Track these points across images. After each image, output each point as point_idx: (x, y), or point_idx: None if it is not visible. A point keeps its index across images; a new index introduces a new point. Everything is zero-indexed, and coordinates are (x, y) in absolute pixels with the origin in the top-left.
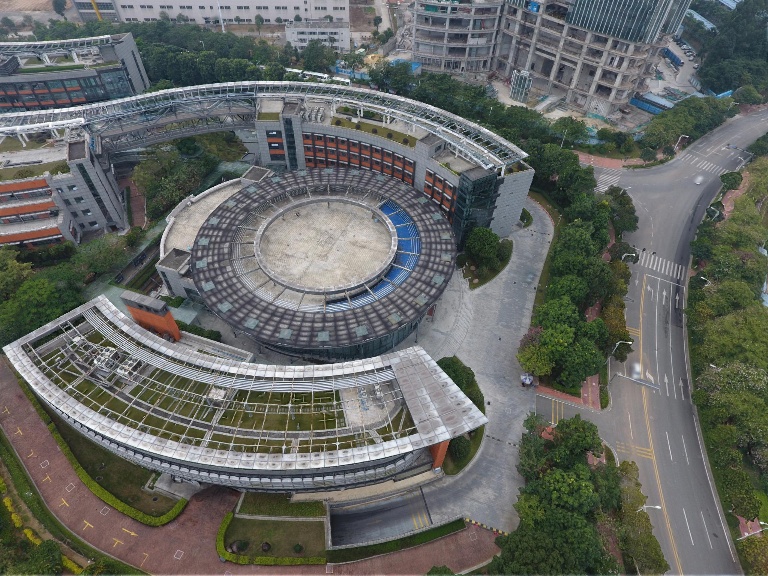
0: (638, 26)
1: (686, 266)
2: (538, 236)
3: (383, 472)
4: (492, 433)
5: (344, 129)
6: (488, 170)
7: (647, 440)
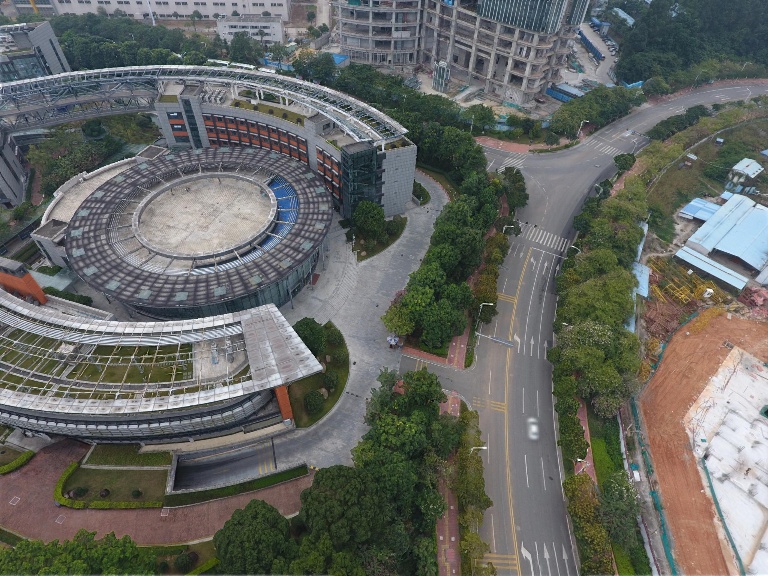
0: (539, 17)
1: (571, 240)
2: (433, 213)
3: (220, 419)
4: (352, 390)
5: (241, 110)
6: (367, 145)
7: (503, 395)
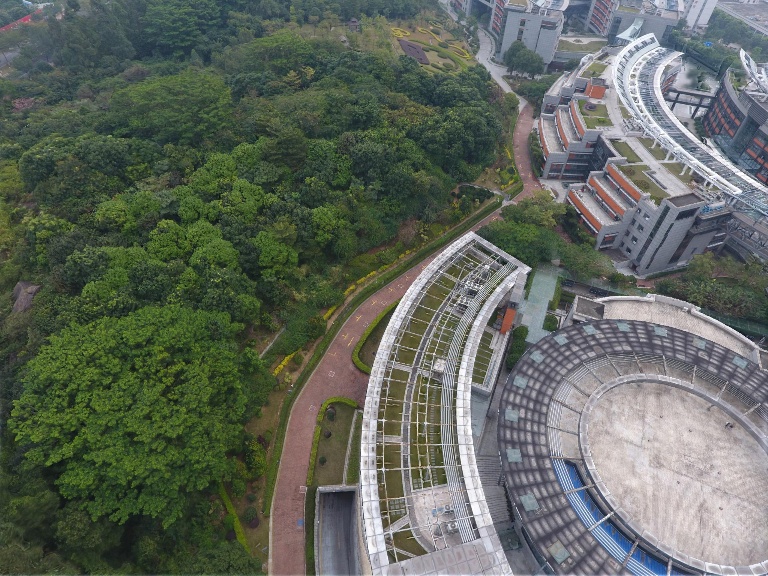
0: None
1: None
2: None
3: None
4: None
5: None
6: None
7: None
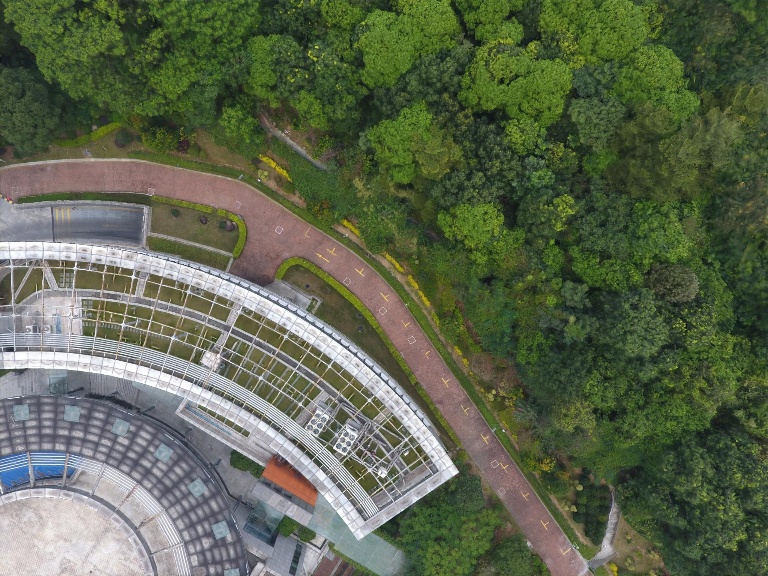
0: None
1: None
2: None
3: None
4: None
5: None
6: None
7: None
